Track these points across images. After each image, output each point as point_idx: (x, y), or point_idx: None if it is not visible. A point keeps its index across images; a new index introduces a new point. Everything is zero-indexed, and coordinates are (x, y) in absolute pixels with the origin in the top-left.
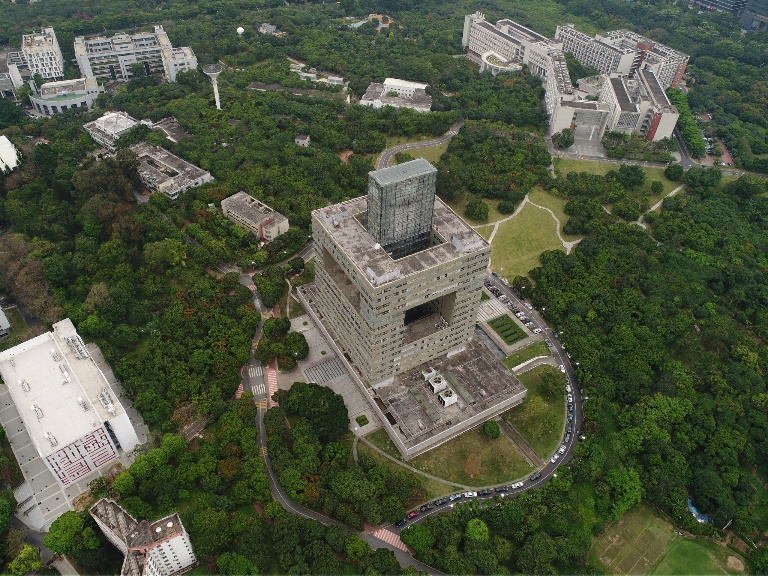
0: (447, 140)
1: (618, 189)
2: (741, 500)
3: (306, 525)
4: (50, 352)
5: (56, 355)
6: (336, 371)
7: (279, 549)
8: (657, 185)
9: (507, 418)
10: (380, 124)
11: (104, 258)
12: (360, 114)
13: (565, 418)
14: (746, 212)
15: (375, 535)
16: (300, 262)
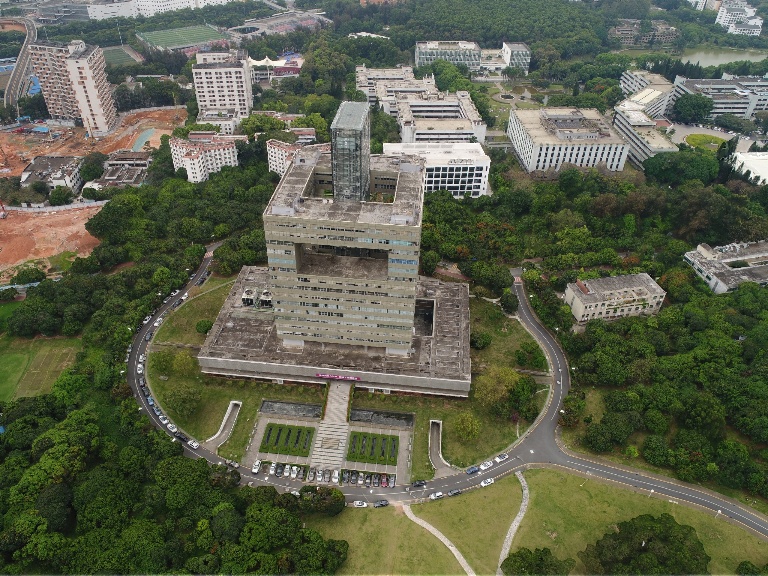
0: None
1: None
2: None
3: None
4: None
5: None
6: None
7: None
8: None
9: None
10: None
11: None
12: None
13: (156, 398)
14: None
15: None
16: (505, 297)
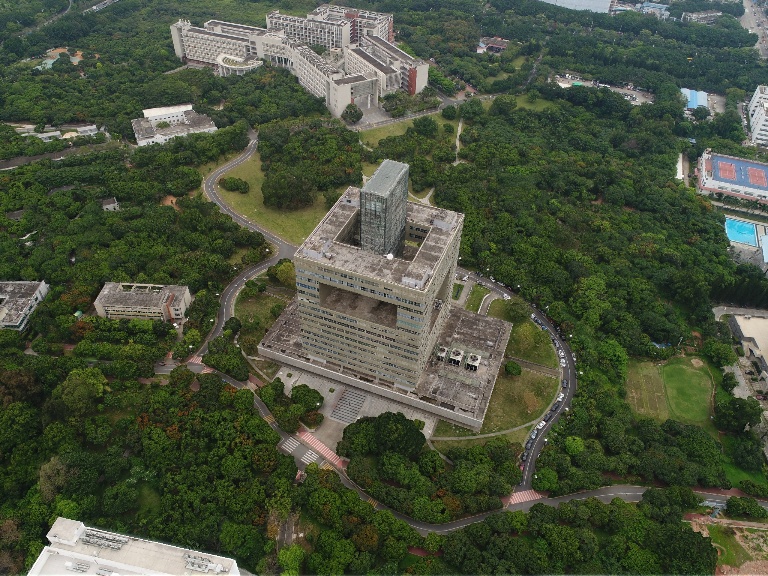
0: (253, 151)
1: (424, 141)
2: (674, 320)
3: (472, 532)
4: (66, 568)
5: (78, 566)
6: (358, 399)
7: (471, 567)
8: (449, 127)
9: (508, 355)
10: (181, 158)
11: (8, 434)
12: (151, 155)
13: None
14: (517, 125)
15: (513, 503)
16: (237, 322)
